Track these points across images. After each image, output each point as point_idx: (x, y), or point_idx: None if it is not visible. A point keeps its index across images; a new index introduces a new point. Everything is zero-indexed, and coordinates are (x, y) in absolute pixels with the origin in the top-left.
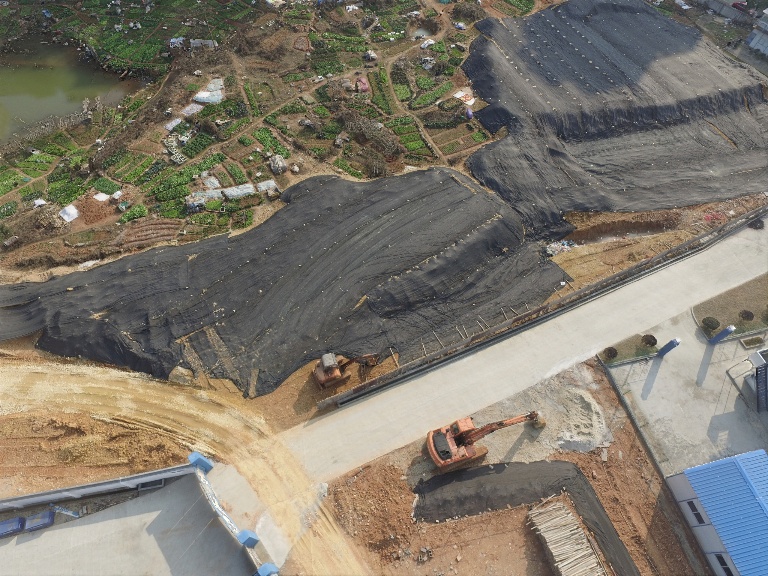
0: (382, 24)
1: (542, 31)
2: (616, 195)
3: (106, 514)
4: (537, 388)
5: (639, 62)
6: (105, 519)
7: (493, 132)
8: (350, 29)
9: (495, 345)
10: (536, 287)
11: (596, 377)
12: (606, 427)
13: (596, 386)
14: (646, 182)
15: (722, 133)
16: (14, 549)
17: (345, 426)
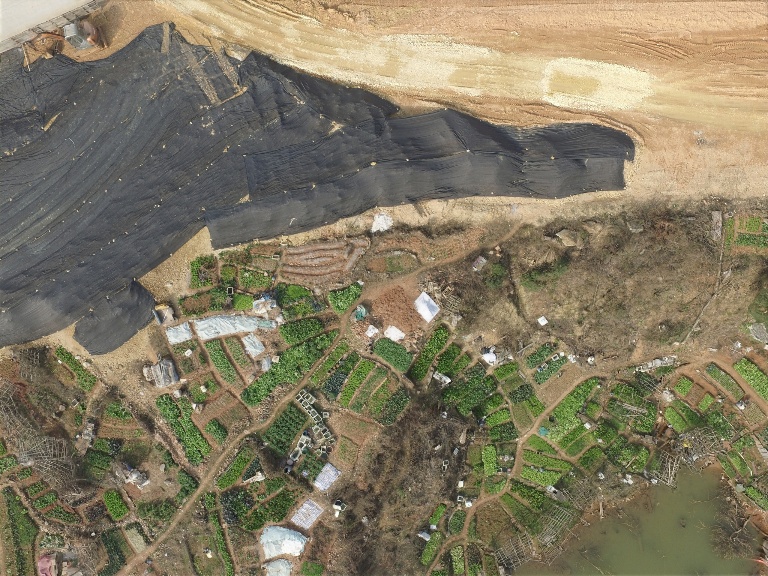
0: None
1: None
2: None
3: None
4: None
5: None
6: None
7: None
8: None
9: None
10: None
11: None
12: None
13: None
14: None
15: None
16: None
17: None
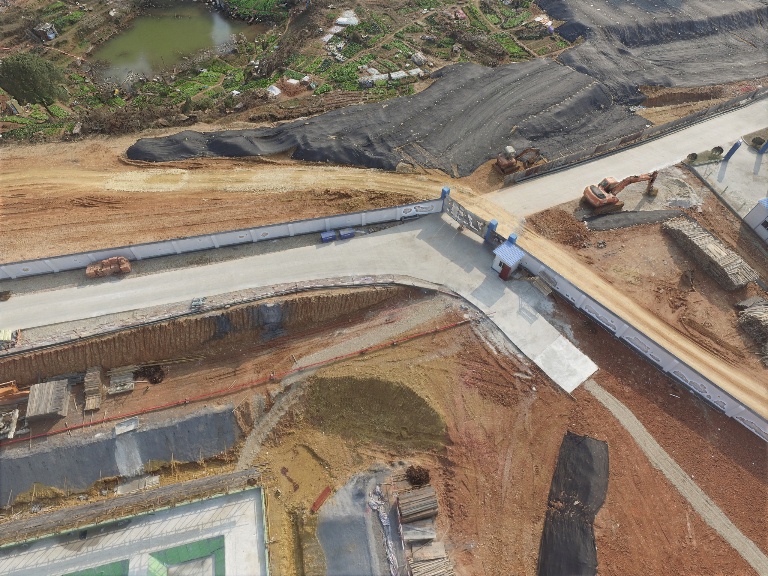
0: None
1: None
2: (673, 78)
3: (387, 231)
4: None
5: None
6: (387, 233)
7: (572, 41)
8: None
9: (610, 156)
10: (629, 127)
11: (684, 172)
12: (697, 196)
13: (685, 176)
14: (693, 70)
15: (744, 40)
16: (335, 247)
17: (525, 192)
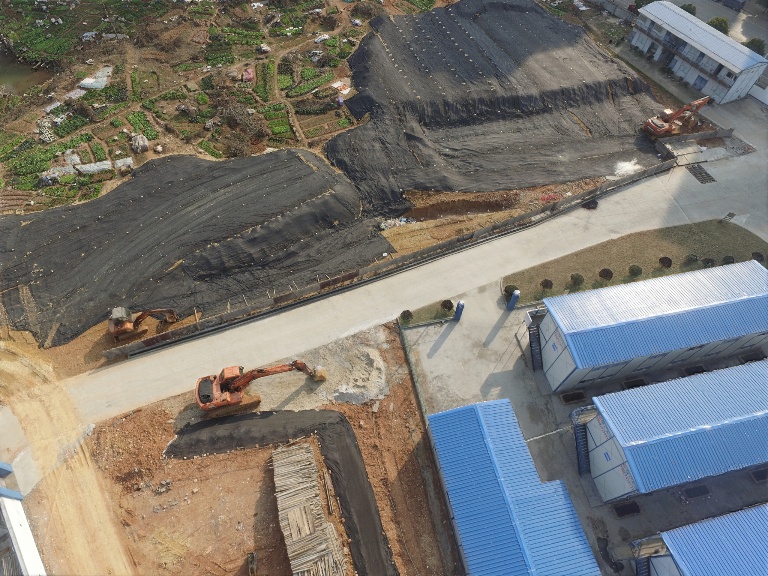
0: (283, 20)
1: (428, 27)
2: (462, 177)
3: None
4: (329, 346)
5: (514, 56)
6: None
7: (358, 118)
8: (250, 24)
9: (300, 308)
10: (358, 257)
11: (389, 337)
12: (385, 382)
13: (387, 345)
14: (495, 165)
15: (581, 122)
16: None
17: (129, 375)
